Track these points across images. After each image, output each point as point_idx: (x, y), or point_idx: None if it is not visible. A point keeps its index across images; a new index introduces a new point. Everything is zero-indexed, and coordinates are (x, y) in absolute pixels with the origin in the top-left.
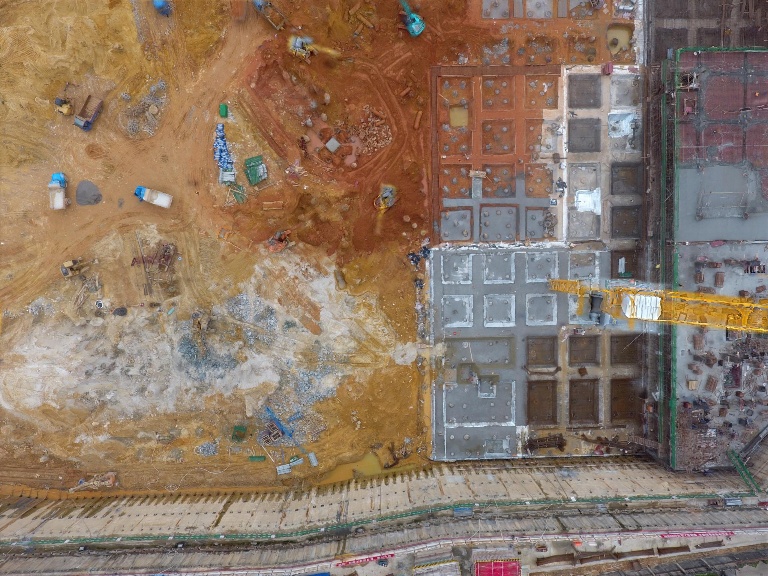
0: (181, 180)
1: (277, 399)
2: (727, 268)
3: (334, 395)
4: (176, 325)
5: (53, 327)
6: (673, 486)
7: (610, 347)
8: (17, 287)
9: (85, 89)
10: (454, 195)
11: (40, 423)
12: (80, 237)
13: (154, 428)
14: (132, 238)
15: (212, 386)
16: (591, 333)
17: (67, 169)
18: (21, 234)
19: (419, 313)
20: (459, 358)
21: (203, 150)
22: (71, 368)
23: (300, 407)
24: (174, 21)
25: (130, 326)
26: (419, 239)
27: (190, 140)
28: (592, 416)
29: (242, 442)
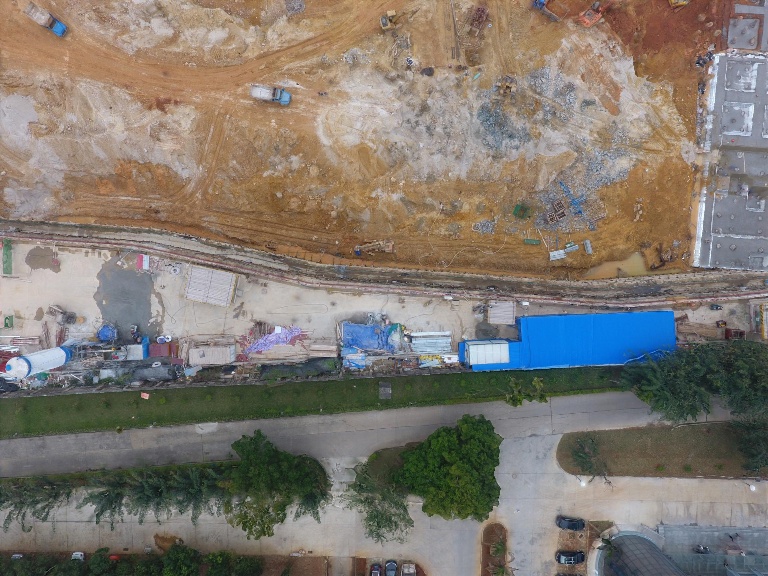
0: None
1: (563, 180)
2: None
3: (625, 178)
4: (479, 91)
5: (370, 74)
6: None
7: None
8: (334, 35)
9: None
10: (744, 3)
11: (347, 168)
12: None
13: (439, 198)
14: (446, 1)
15: (507, 156)
16: None
17: None
18: None
19: (698, 118)
20: (732, 168)
21: None
22: (392, 109)
23: (584, 191)
24: None
25: (440, 84)
26: (707, 42)
27: None
28: None
29: (519, 223)
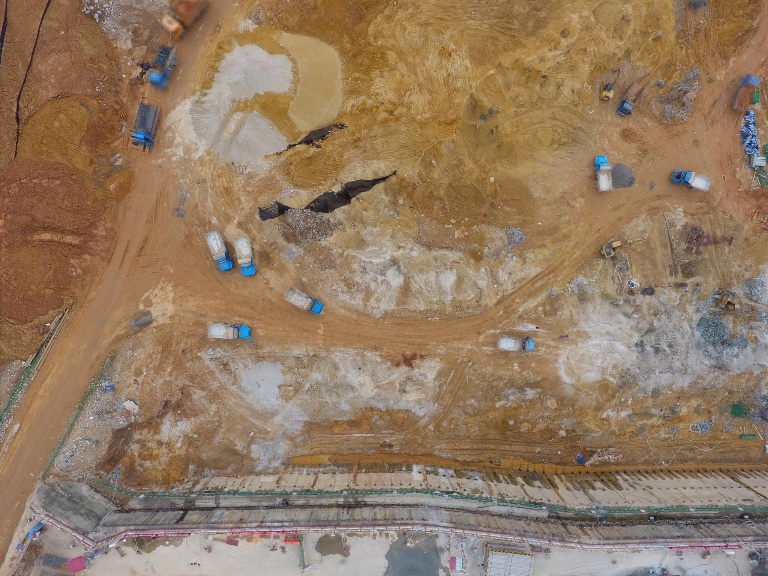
0: (709, 164)
1: None
2: None
3: None
4: (698, 305)
5: None
6: None
7: None
8: (557, 266)
9: (620, 75)
10: None
11: (583, 398)
12: (612, 219)
13: (659, 405)
14: (660, 220)
15: (728, 365)
16: None
17: (602, 153)
18: (558, 215)
19: None
20: None
21: (730, 136)
22: (631, 344)
23: None
24: (710, 10)
25: (665, 305)
26: None
27: (718, 126)
28: None
29: (736, 420)
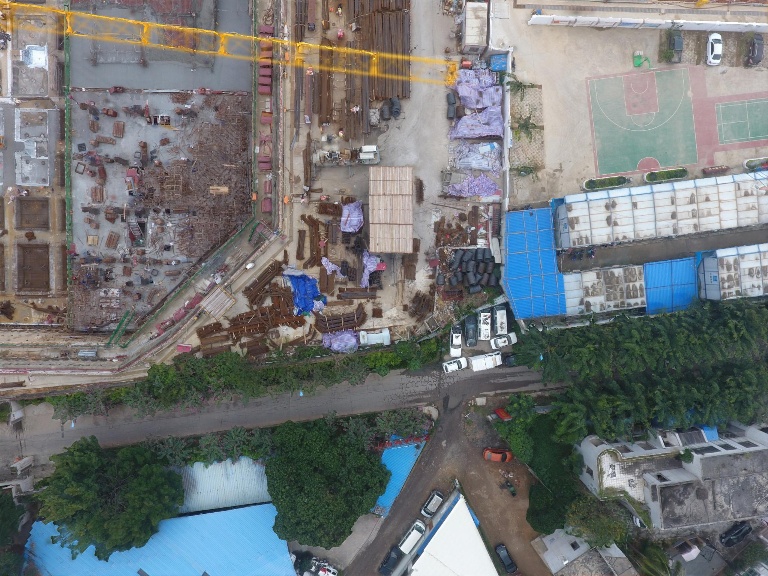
0: None
1: None
2: (128, 118)
3: None
4: None
5: None
6: (43, 339)
7: (61, 211)
8: None
9: None
10: None
11: None
12: None
13: None
14: None
15: None
16: (40, 196)
17: None
18: None
19: None
20: None
21: None
22: None
23: None
24: None
25: None
26: None
27: None
28: (45, 284)
29: None
